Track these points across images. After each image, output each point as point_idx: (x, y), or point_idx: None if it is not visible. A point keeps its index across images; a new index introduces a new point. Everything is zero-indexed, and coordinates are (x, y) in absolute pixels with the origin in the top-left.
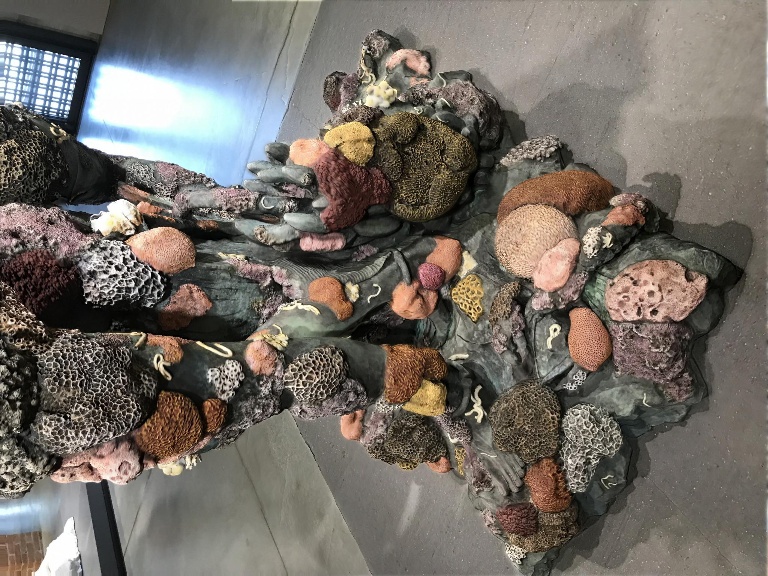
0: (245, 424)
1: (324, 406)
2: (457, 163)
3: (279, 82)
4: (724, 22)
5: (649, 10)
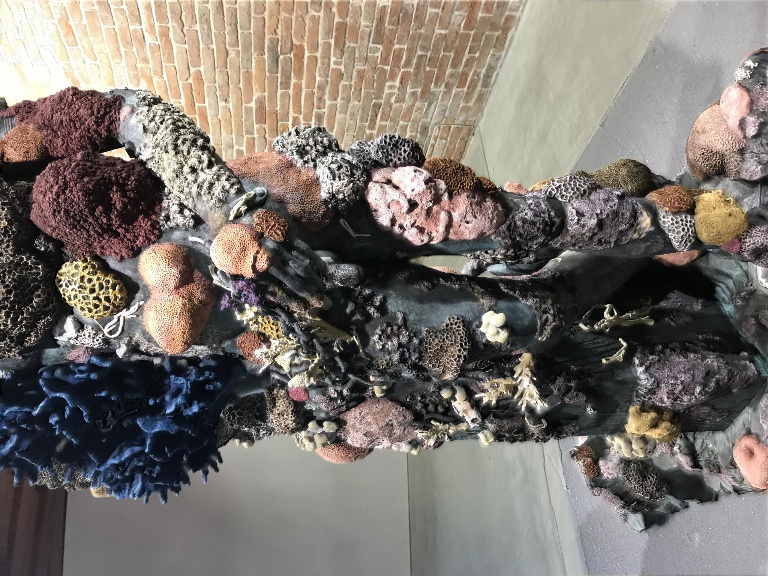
0: (524, 212)
1: (593, 200)
2: (628, 165)
3: (555, 483)
4: (719, 4)
5: (687, 59)
